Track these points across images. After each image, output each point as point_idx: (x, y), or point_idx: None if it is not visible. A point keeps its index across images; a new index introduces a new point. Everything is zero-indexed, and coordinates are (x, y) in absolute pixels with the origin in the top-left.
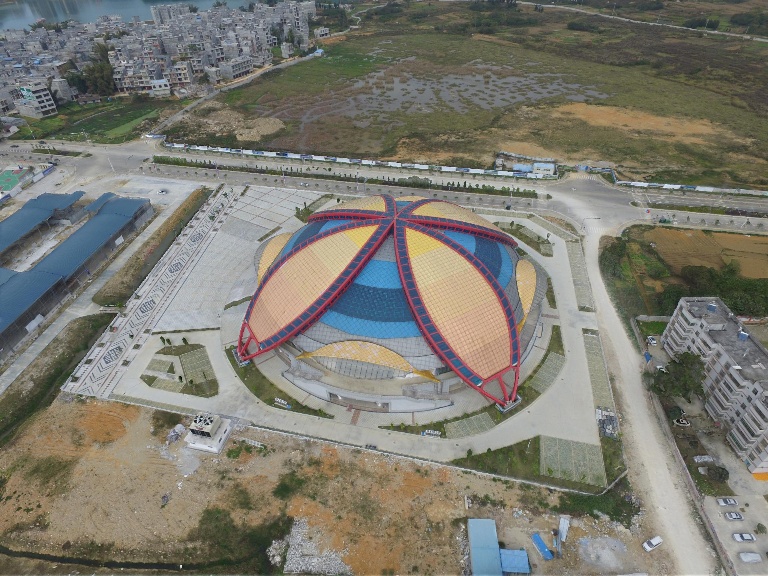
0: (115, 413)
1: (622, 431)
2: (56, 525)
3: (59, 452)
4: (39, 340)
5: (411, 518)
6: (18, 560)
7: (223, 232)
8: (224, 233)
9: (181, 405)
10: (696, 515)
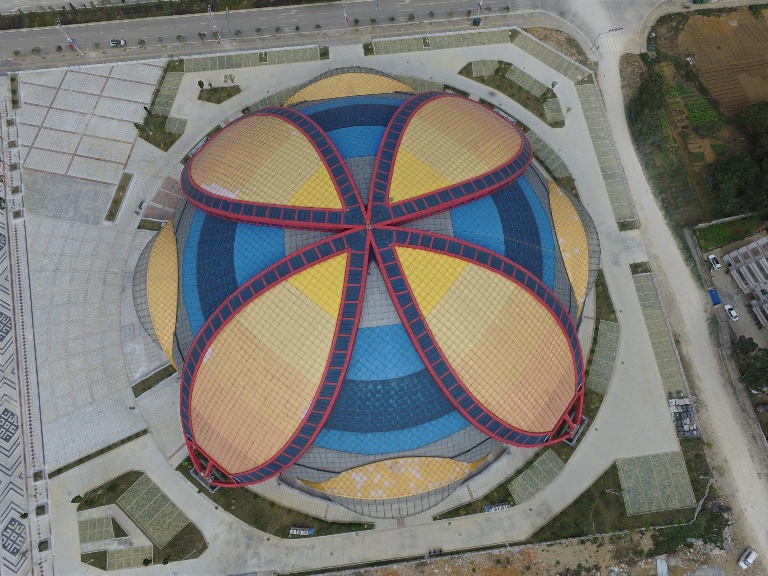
0: None
1: (699, 420)
2: None
3: None
4: None
5: None
6: None
7: (35, 215)
8: (38, 217)
9: None
10: None
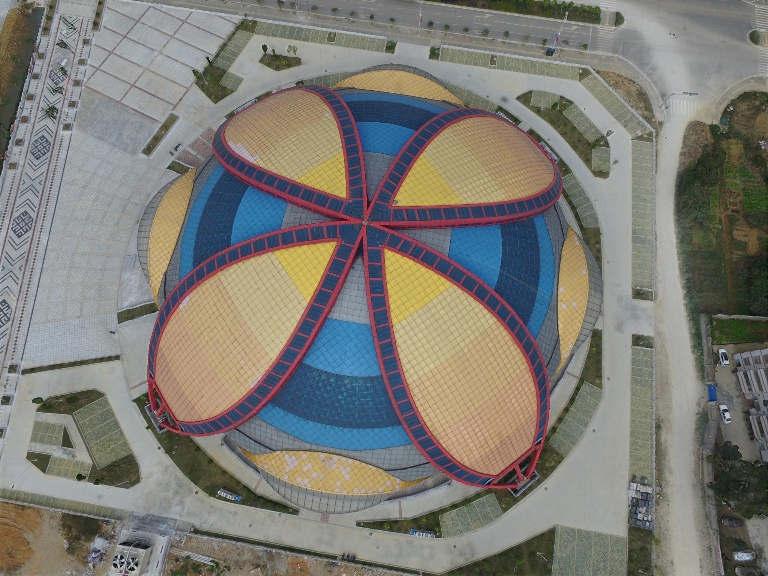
0: (10, 520)
1: (657, 513)
2: None
3: None
4: None
5: None
6: None
7: (82, 132)
8: (84, 134)
9: (95, 503)
10: None
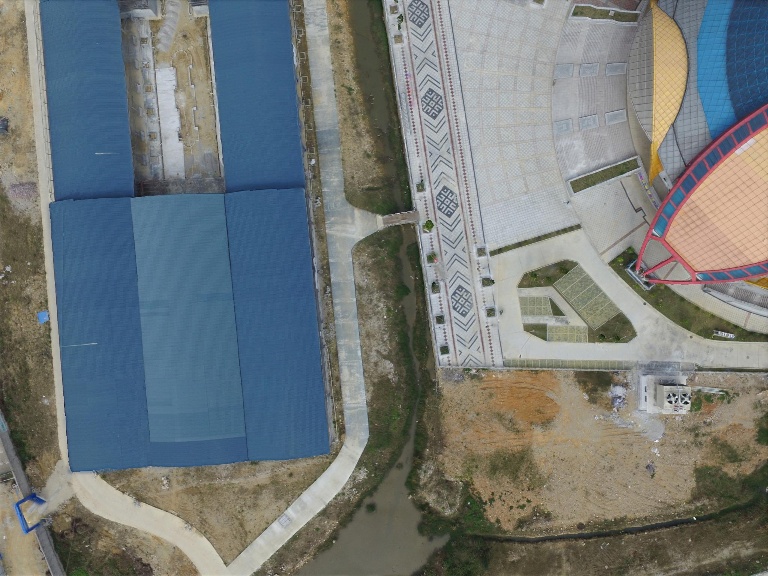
0: (528, 384)
1: None
2: (561, 514)
3: (502, 444)
4: (337, 295)
5: None
6: (545, 546)
7: None
8: None
9: (600, 359)
10: None
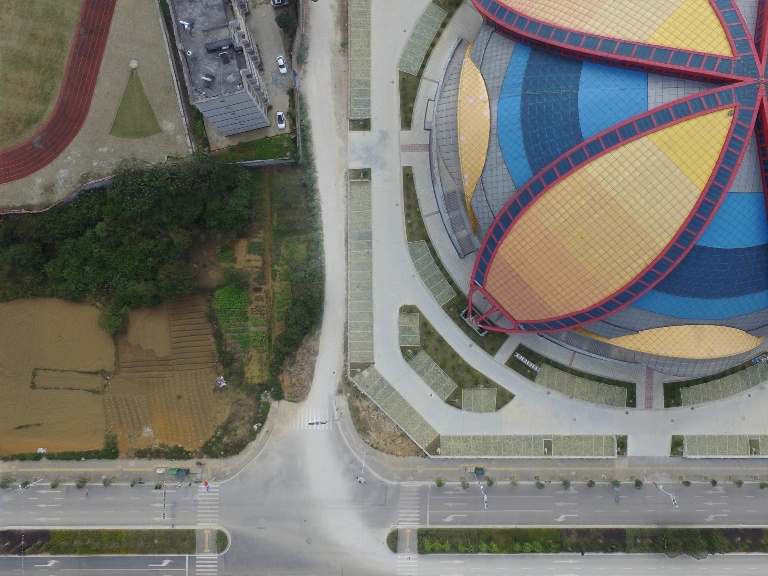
0: None
1: None
2: None
3: None
4: None
5: None
6: None
7: None
8: None
9: None
10: None
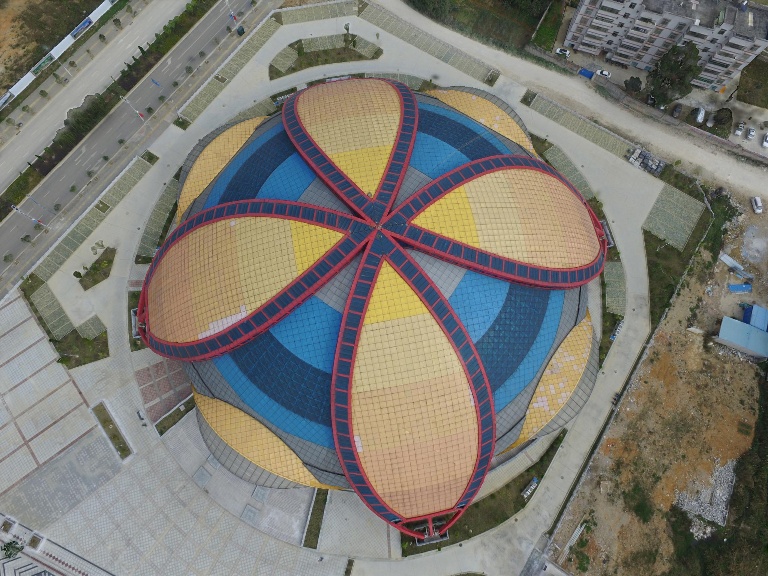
0: None
1: (655, 155)
2: None
3: None
4: None
5: (698, 388)
6: None
7: (52, 525)
8: (57, 524)
9: None
10: (739, 158)
